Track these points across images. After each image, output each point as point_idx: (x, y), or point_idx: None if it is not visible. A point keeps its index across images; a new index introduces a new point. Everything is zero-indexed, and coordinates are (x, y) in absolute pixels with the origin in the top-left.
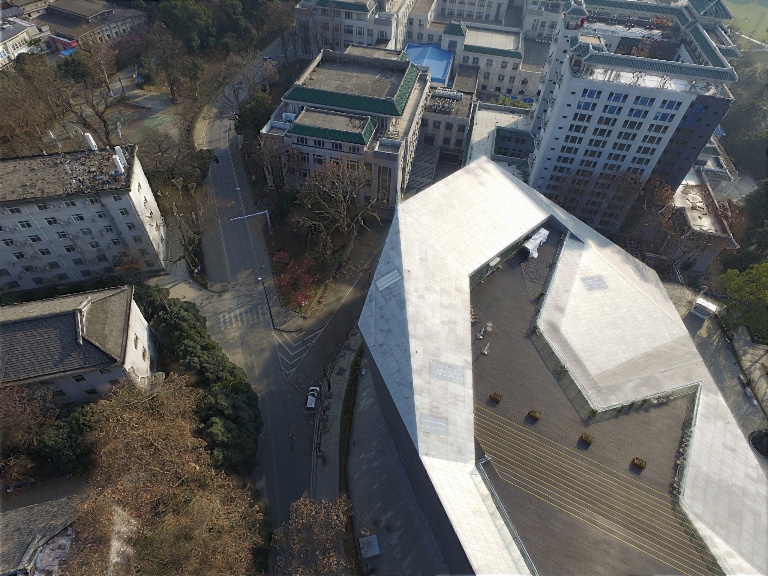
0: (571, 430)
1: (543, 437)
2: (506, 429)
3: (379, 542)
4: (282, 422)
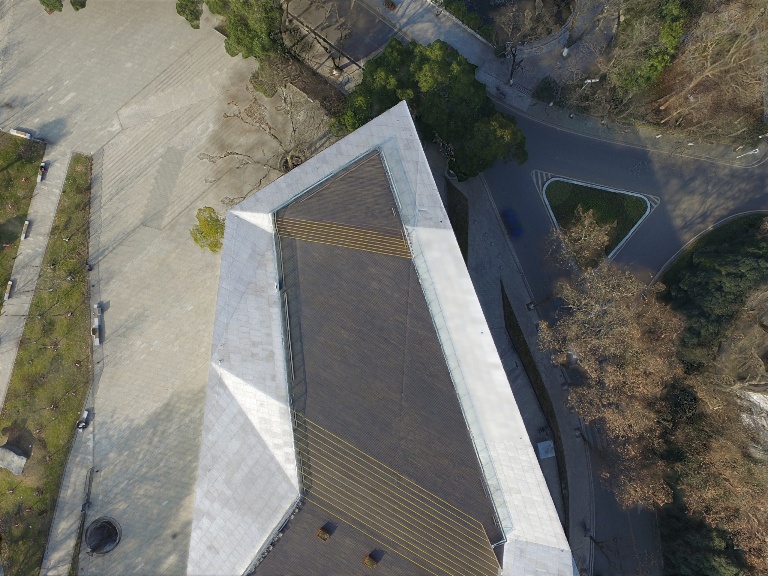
0: (385, 573)
1: (419, 565)
2: (458, 575)
3: (536, 452)
4: (628, 569)
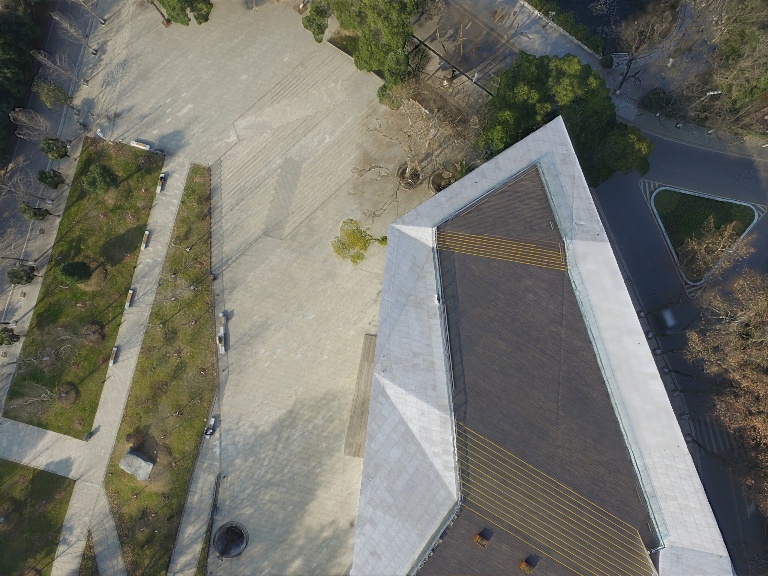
0: None
1: (574, 570)
2: None
3: None
4: (738, 572)
